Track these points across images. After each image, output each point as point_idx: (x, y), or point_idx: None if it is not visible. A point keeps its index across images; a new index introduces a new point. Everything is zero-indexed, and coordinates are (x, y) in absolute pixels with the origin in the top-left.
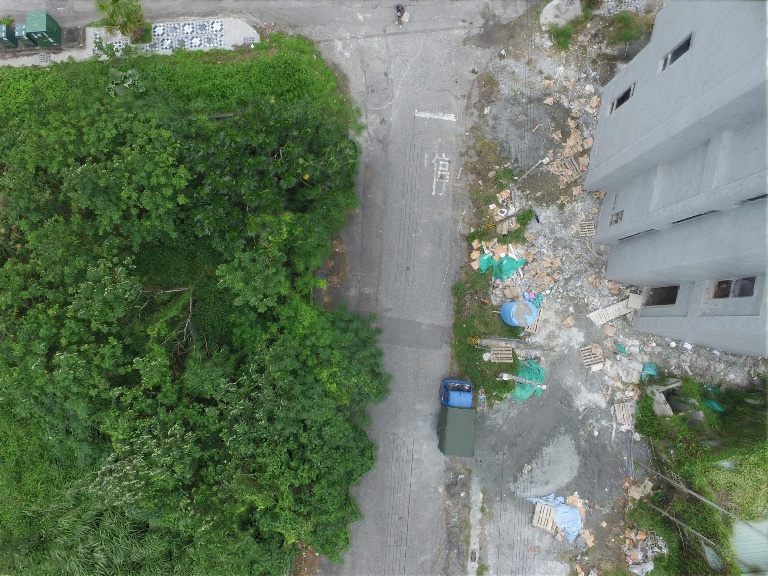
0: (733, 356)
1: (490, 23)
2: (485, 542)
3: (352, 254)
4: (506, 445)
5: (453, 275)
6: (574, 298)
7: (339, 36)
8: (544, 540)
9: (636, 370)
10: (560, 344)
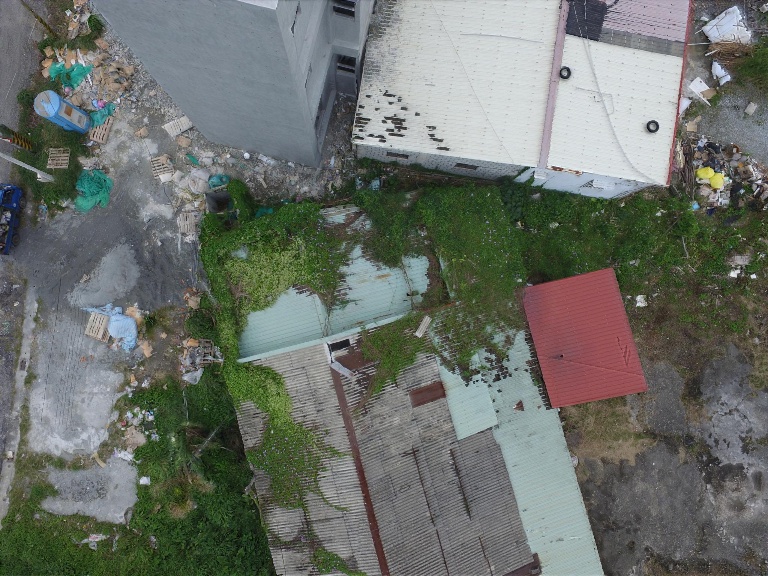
0: (307, 168)
1: None
2: (36, 351)
3: None
4: (64, 255)
5: (21, 82)
6: (150, 109)
7: None
8: (98, 350)
9: (202, 179)
10: (131, 155)
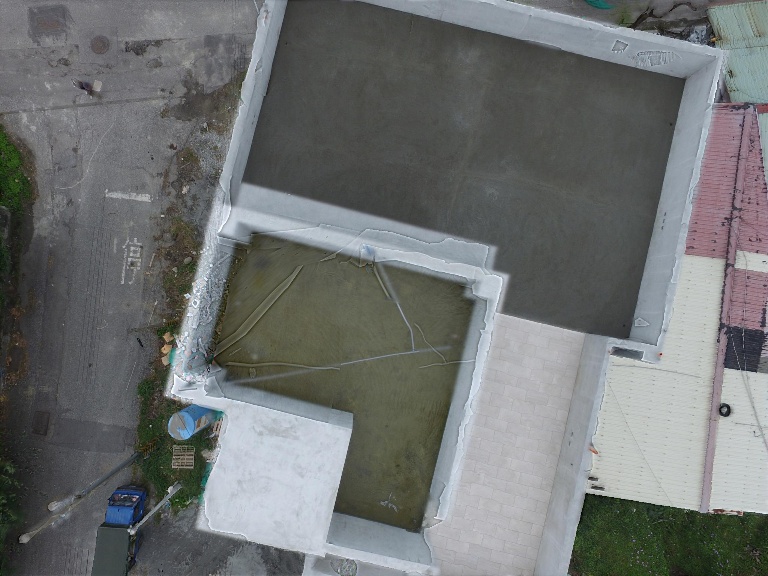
0: None
1: (192, 92)
2: None
3: (32, 349)
4: (189, 554)
5: (141, 371)
6: None
7: (23, 107)
8: None
9: None
10: None
